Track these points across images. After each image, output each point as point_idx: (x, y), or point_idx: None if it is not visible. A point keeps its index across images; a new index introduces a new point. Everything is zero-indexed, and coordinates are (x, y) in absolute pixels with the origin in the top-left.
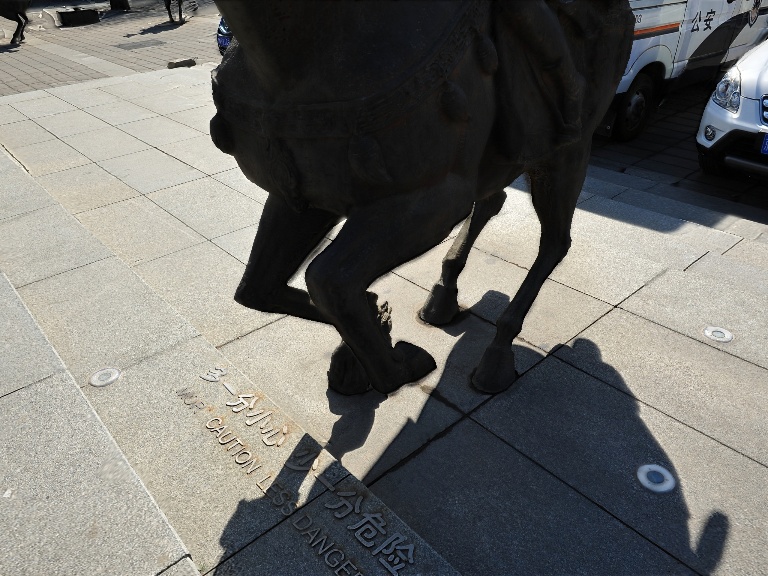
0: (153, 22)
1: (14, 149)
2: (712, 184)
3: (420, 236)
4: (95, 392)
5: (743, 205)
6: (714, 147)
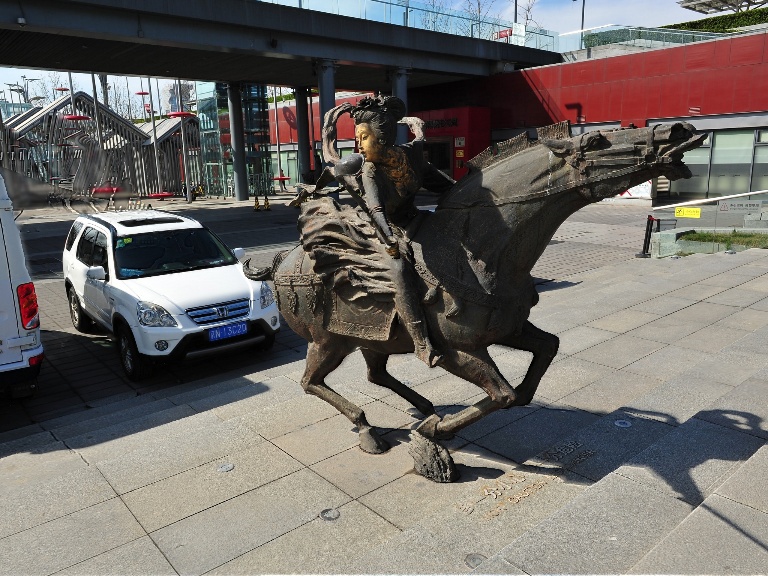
0: None
1: None
2: (154, 383)
3: None
4: None
5: (210, 377)
6: (175, 352)
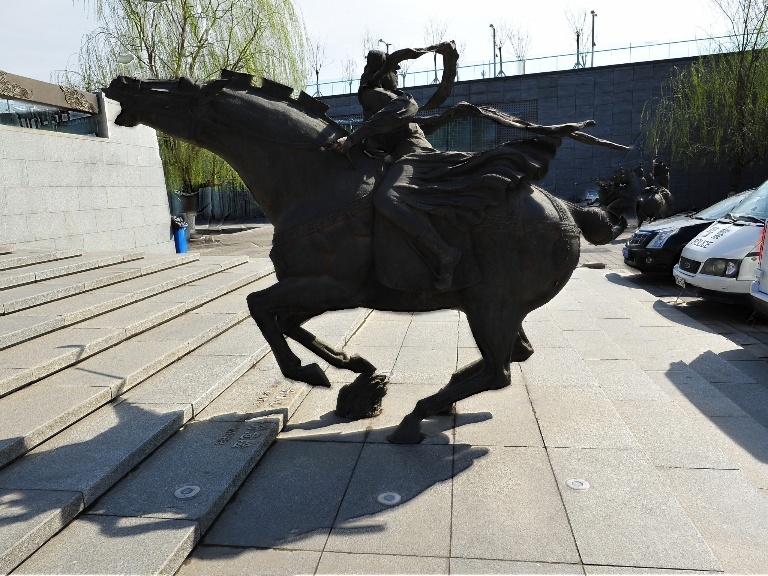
0: (624, 236)
1: None
2: None
3: (299, 297)
4: None
5: None
6: None
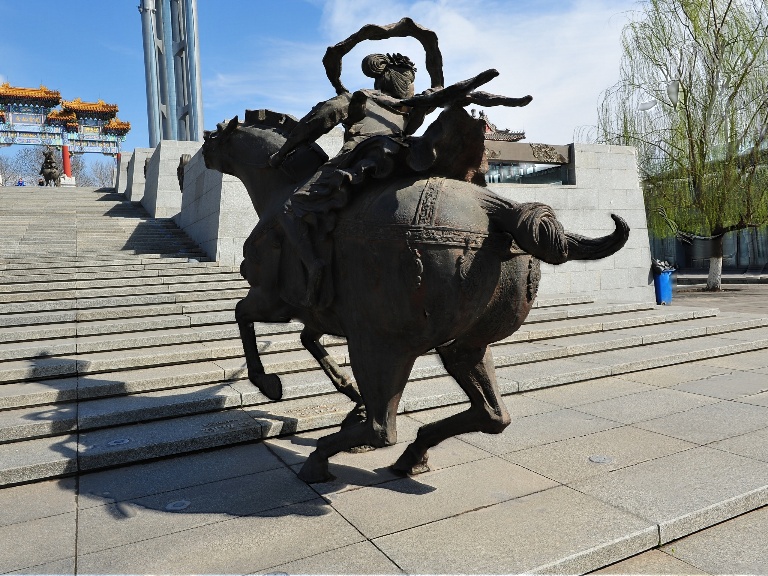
0: None
1: (766, 353)
2: None
3: None
4: None
5: None
6: None
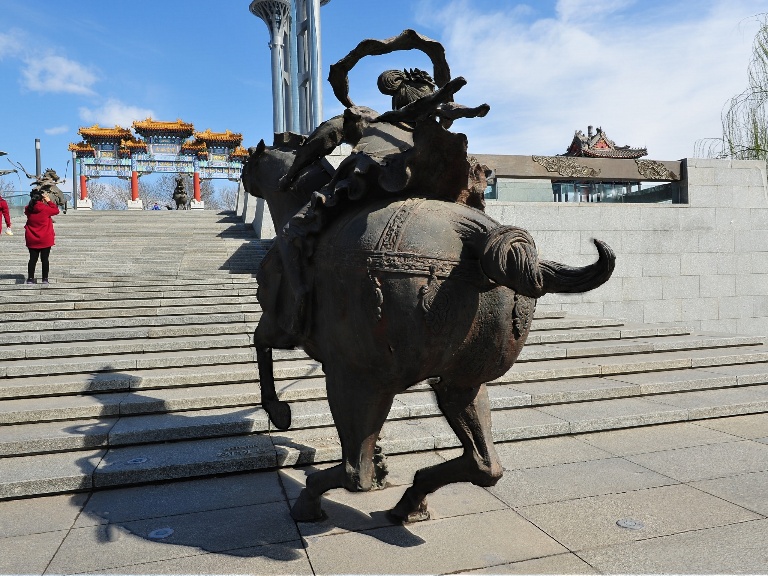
0: None
1: None
2: None
3: None
4: (403, 422)
5: None
6: None
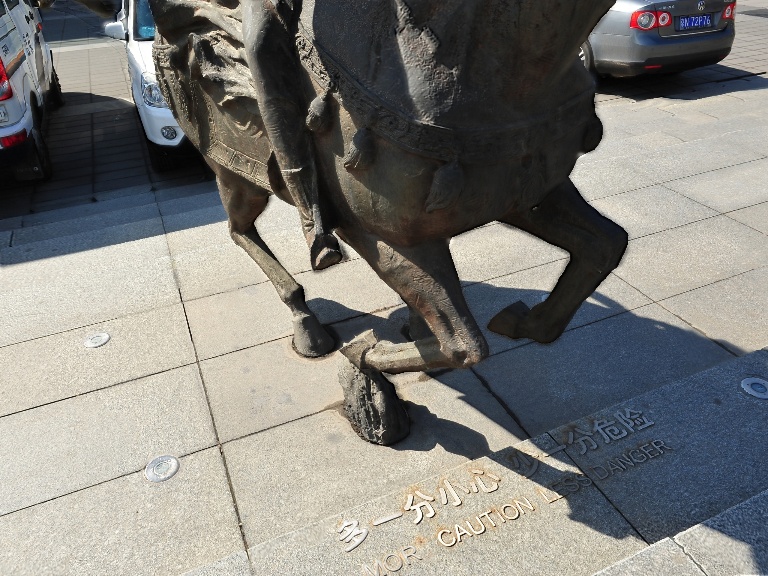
0: None
1: None
2: (176, 177)
3: None
4: None
5: None
6: (183, 142)
